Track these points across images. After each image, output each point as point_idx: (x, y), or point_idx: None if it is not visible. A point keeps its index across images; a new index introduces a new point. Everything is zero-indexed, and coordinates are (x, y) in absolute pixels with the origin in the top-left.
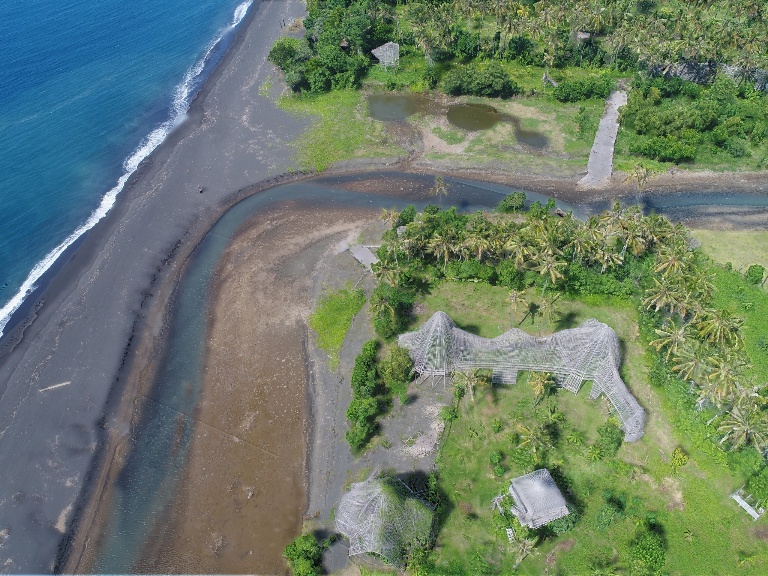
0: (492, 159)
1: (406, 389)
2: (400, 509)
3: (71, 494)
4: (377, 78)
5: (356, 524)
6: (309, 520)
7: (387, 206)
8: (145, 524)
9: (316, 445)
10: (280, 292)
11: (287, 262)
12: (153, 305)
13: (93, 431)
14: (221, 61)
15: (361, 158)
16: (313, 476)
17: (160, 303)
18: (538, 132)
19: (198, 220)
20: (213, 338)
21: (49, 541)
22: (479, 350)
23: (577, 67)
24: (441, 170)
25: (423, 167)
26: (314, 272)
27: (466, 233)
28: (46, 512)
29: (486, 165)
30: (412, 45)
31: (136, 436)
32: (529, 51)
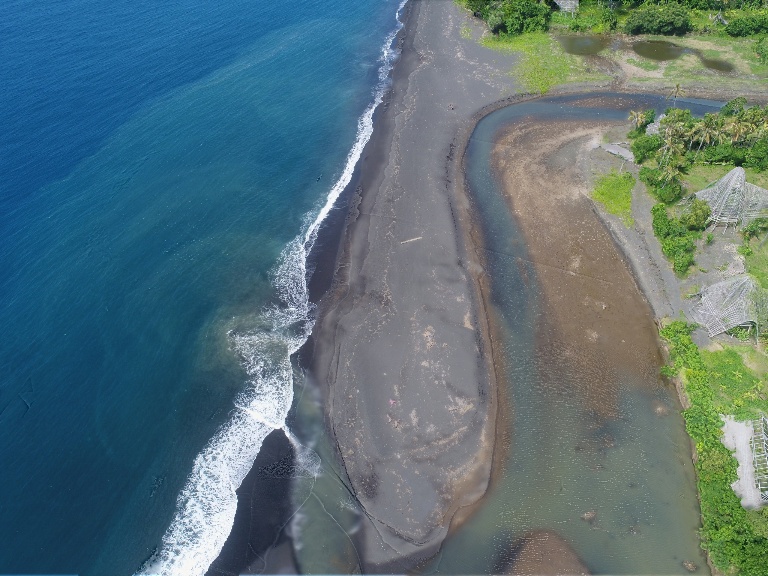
0: (692, 80)
1: (701, 236)
2: (762, 292)
3: (465, 306)
4: (560, 22)
5: (718, 310)
6: (665, 318)
7: (614, 117)
8: (529, 326)
9: (640, 275)
10: (556, 177)
11: (550, 157)
12: (455, 188)
13: (458, 268)
14: (409, 14)
15: (576, 82)
16: (648, 294)
17: (459, 187)
18: (721, 60)
19: (459, 129)
20: (516, 209)
21: (467, 334)
22: (766, 200)
23: (737, 9)
24: (649, 90)
25: (632, 88)
26: (577, 163)
27: (726, 119)
28: (452, 317)
29: (689, 85)
30: None
31: (490, 273)
32: None
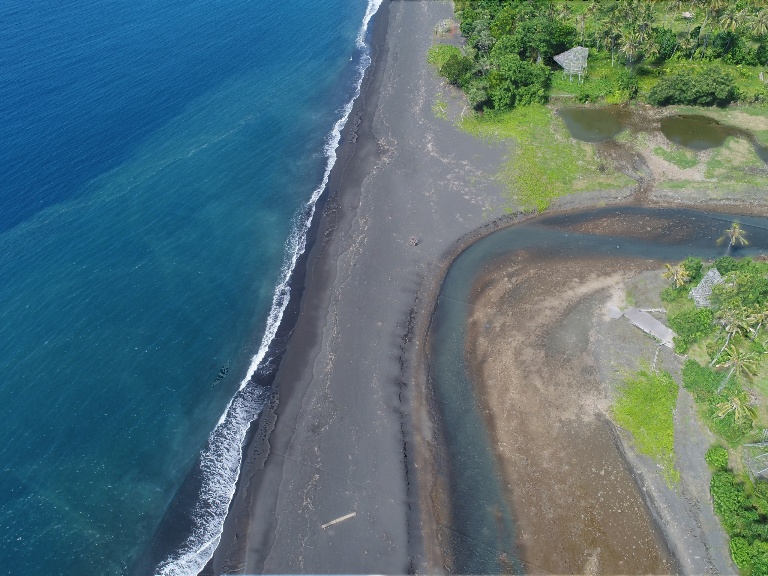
0: (746, 186)
1: None
2: None
3: None
4: (564, 89)
5: None
6: None
7: (640, 253)
8: None
9: None
10: (559, 375)
11: (552, 333)
12: (412, 398)
13: None
14: (371, 77)
15: (586, 191)
16: None
17: (418, 395)
18: None
19: (424, 281)
20: (501, 442)
21: None
22: None
23: None
24: (687, 203)
25: (663, 199)
26: (590, 346)
27: None
28: None
29: (742, 194)
30: (593, 47)
31: None
32: (740, 48)
